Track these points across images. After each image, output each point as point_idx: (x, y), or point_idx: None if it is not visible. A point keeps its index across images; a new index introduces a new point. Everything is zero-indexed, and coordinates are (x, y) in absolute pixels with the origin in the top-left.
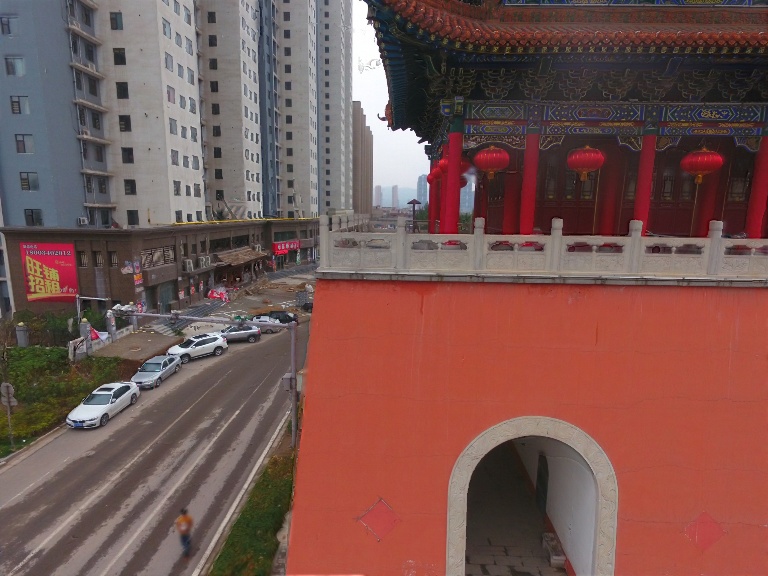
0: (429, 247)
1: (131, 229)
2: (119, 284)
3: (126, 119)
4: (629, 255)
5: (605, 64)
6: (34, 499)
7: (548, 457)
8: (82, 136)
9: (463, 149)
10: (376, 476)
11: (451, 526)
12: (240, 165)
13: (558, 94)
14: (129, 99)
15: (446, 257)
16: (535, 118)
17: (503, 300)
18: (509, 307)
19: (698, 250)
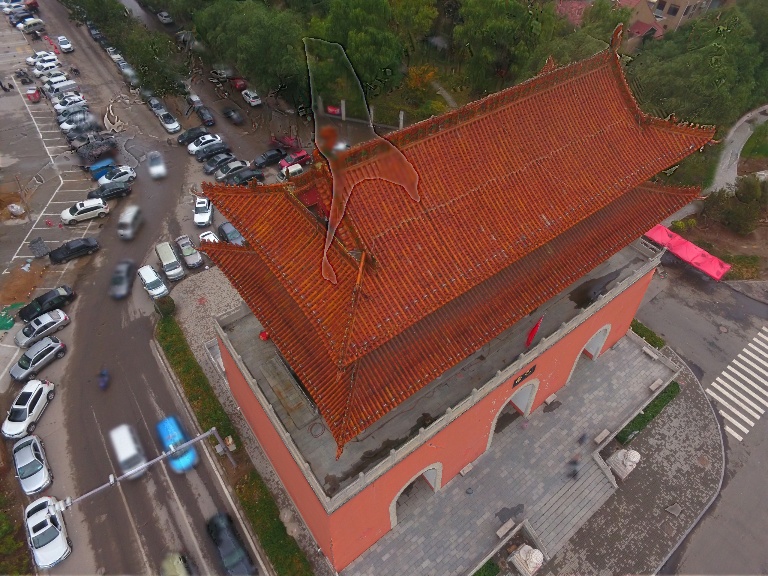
0: None
1: None
2: None
3: None
4: None
5: None
6: None
7: None
8: None
9: None
10: None
11: None
12: None
13: None
14: None
15: None
16: None
17: None
18: None
19: (468, 399)
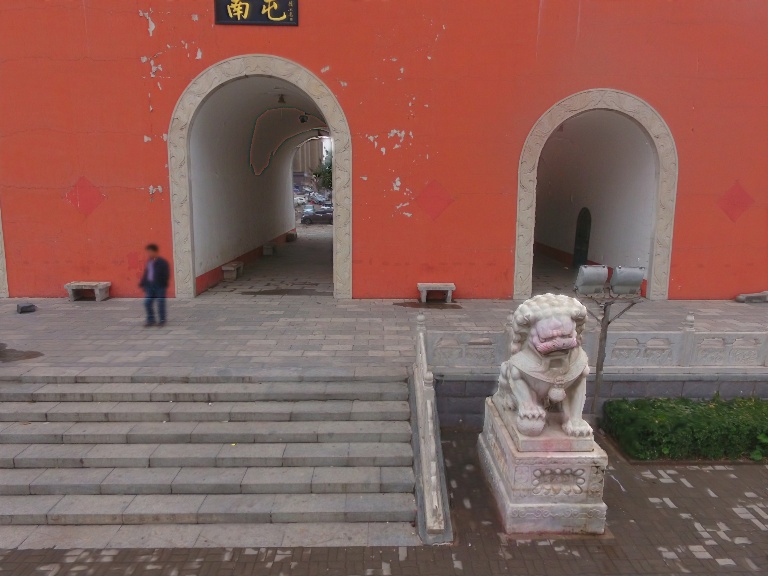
0: None
1: None
2: None
3: None
4: None
5: None
6: None
7: None
8: None
9: None
10: None
11: None
12: None
13: None
14: None
15: None
16: None
17: None
18: None
19: None
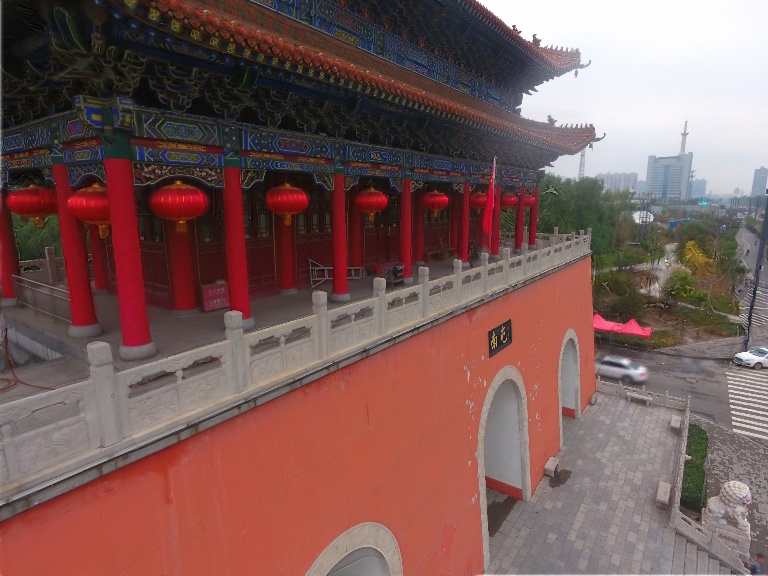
0: (21, 327)
1: None
2: None
3: None
4: (379, 316)
5: (304, 89)
6: None
7: None
8: None
9: (134, 186)
10: None
11: None
12: None
13: (253, 115)
14: None
15: (193, 389)
16: (234, 146)
17: (280, 419)
18: (289, 425)
19: (416, 297)
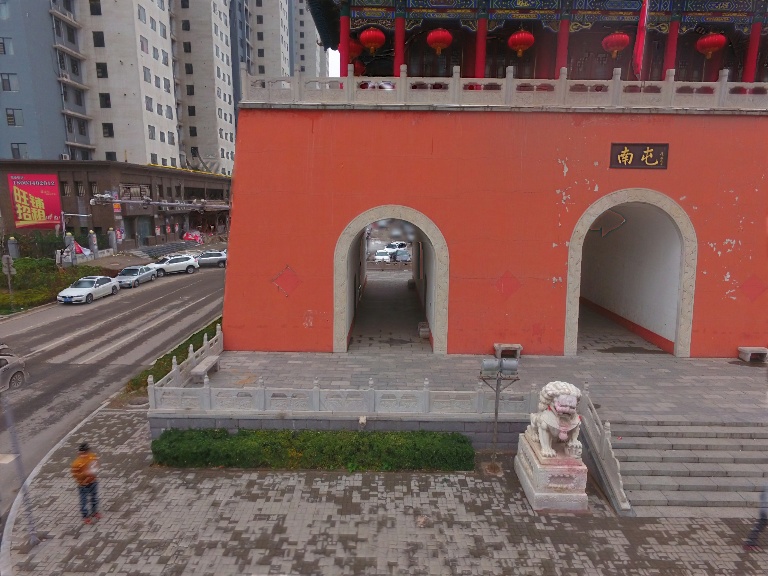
0: None
1: (109, 161)
2: (100, 212)
3: (103, 66)
4: (452, 90)
5: None
6: (34, 332)
7: (426, 273)
8: (62, 79)
9: (351, 29)
10: (284, 250)
11: (336, 284)
12: (213, 123)
13: None
14: (105, 47)
15: (329, 93)
16: (400, 5)
17: (368, 123)
18: (372, 128)
19: (499, 87)
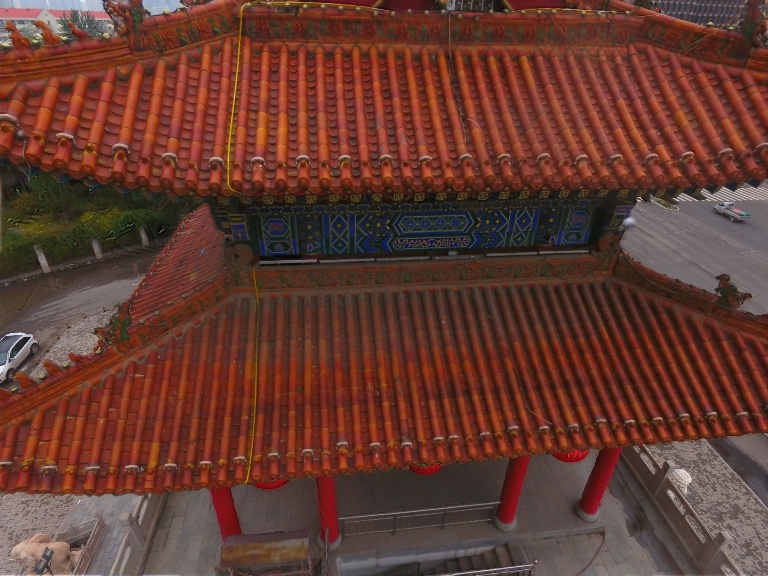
0: (399, 552)
1: None
2: None
3: None
4: None
5: None
6: None
7: None
8: None
9: None
10: None
11: None
12: None
13: None
14: None
15: None
16: None
17: None
18: None
19: None
